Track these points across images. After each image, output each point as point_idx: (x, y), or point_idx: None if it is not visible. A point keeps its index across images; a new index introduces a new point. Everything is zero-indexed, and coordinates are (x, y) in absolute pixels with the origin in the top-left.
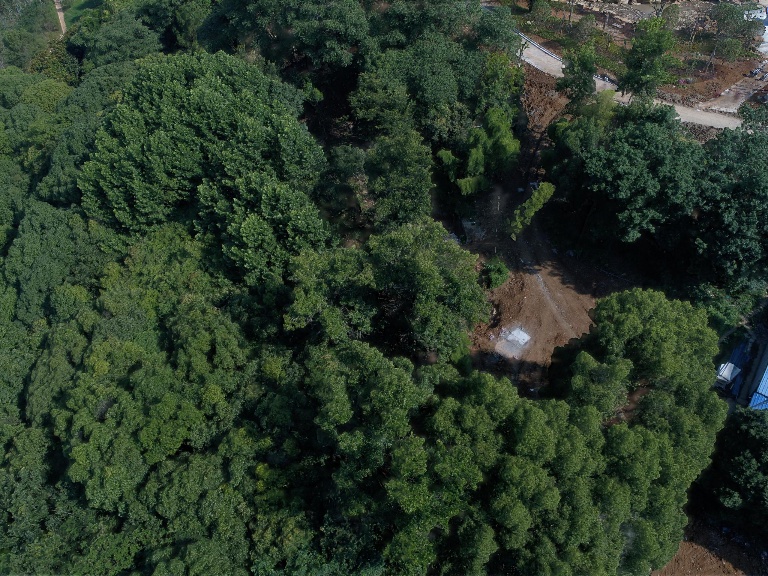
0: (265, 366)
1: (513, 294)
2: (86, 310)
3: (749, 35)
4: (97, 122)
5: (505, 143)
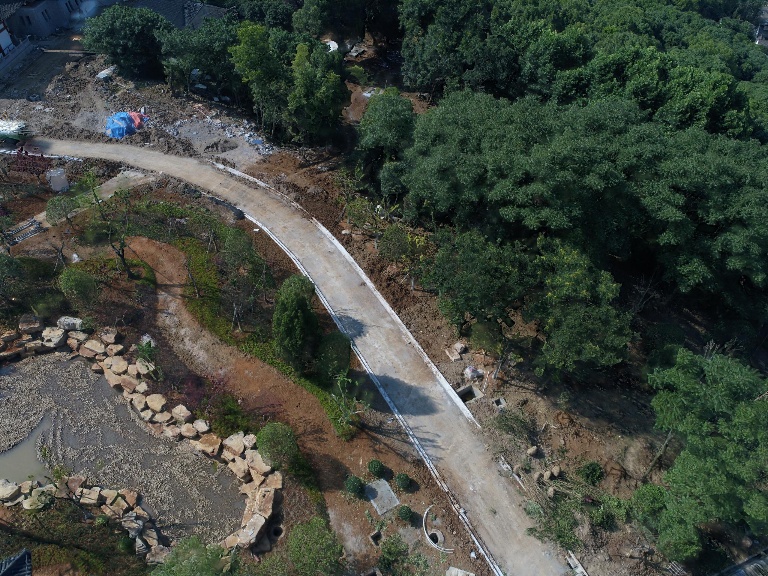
0: (497, 8)
1: None
2: (615, 48)
3: None
4: (763, 122)
5: None
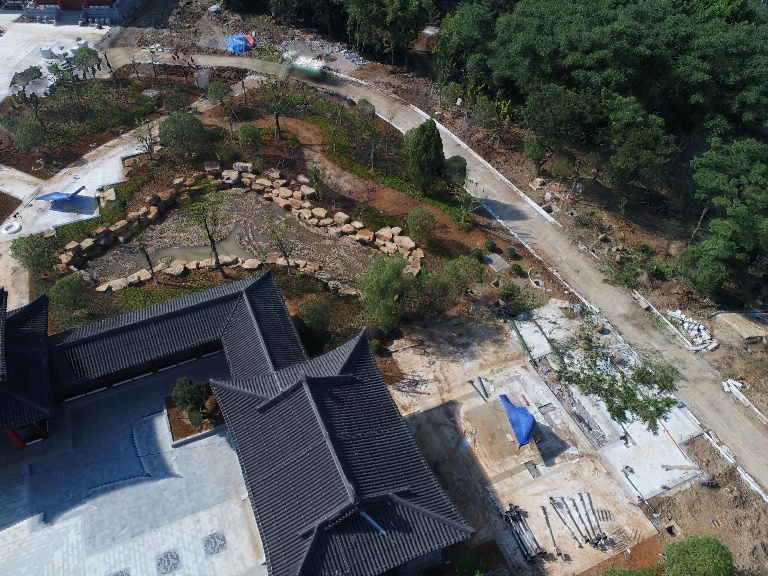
0: None
1: (432, 44)
2: None
3: (187, 99)
4: None
5: None
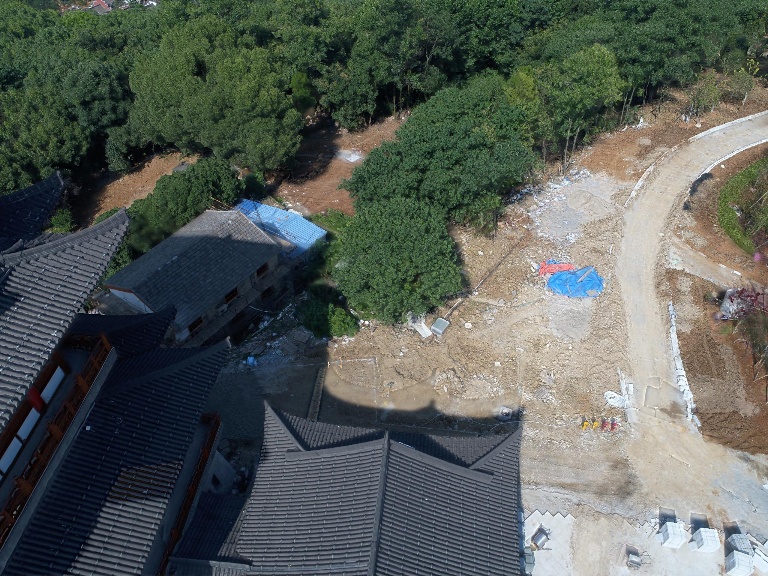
0: None
1: None
2: None
3: None
4: None
5: (502, 88)
